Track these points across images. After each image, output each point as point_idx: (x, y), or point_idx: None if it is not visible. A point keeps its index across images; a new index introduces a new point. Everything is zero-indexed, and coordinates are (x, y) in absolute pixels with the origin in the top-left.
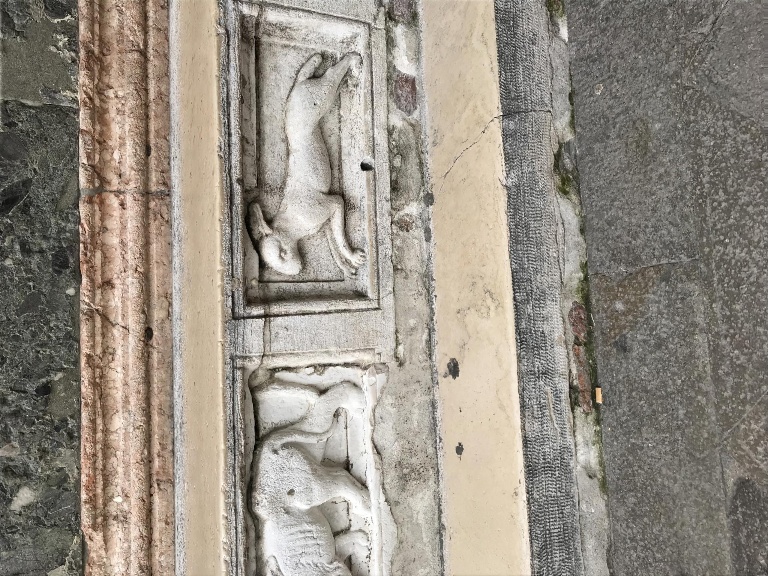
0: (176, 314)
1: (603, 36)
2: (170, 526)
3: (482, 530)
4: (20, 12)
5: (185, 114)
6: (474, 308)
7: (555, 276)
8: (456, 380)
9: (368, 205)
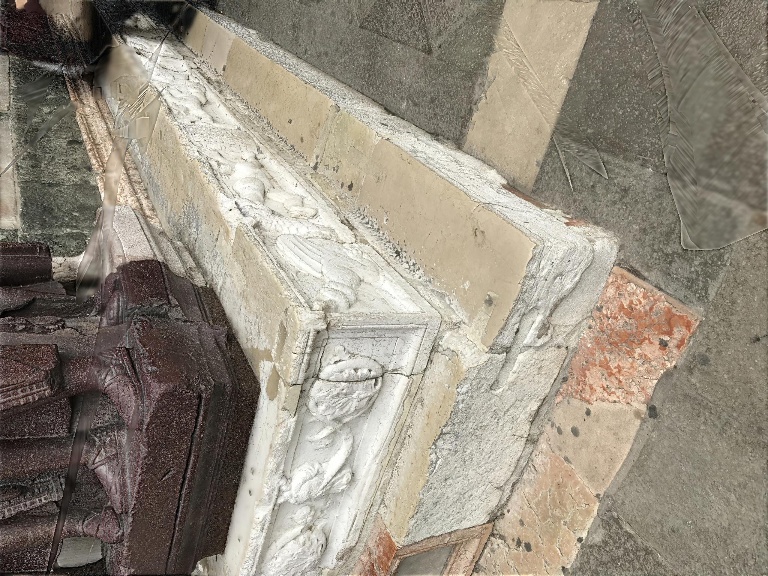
0: None
1: None
2: (106, 105)
3: None
4: (41, 54)
5: (93, 43)
6: None
7: (199, 3)
8: (182, 28)
9: (148, 24)
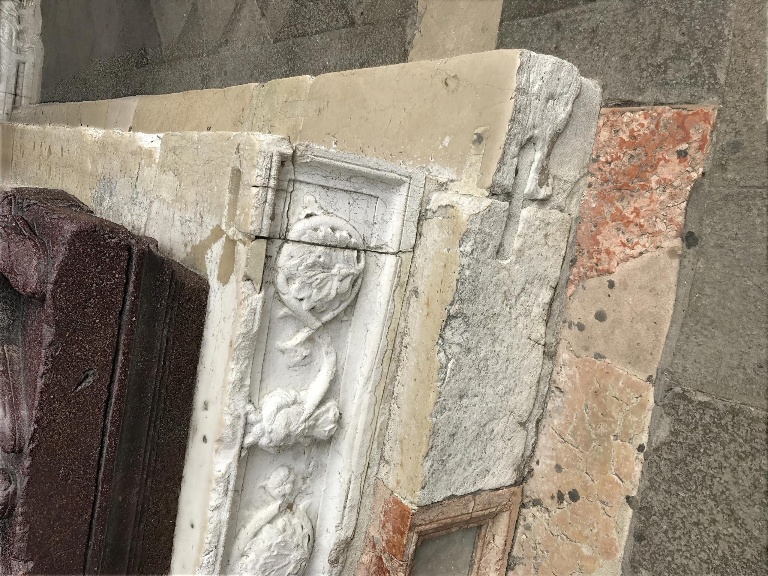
0: None
1: (95, 98)
2: None
3: (95, 117)
4: None
5: None
6: None
7: None
8: None
9: None
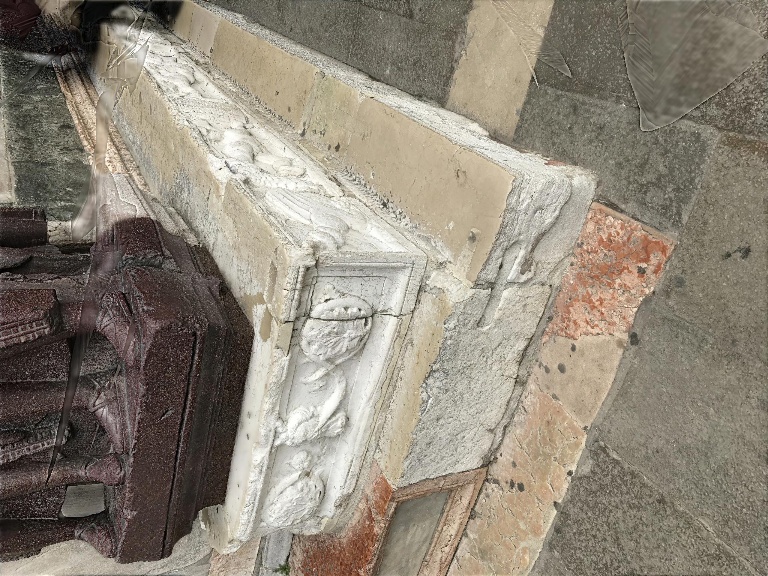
0: (88, 68)
1: None
2: None
3: (181, 16)
4: None
5: None
6: (166, 3)
7: None
8: (169, 17)
9: None
